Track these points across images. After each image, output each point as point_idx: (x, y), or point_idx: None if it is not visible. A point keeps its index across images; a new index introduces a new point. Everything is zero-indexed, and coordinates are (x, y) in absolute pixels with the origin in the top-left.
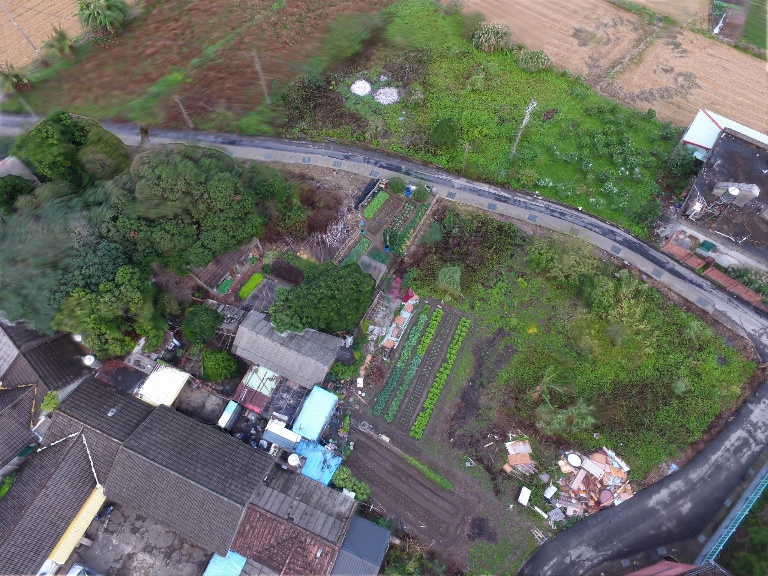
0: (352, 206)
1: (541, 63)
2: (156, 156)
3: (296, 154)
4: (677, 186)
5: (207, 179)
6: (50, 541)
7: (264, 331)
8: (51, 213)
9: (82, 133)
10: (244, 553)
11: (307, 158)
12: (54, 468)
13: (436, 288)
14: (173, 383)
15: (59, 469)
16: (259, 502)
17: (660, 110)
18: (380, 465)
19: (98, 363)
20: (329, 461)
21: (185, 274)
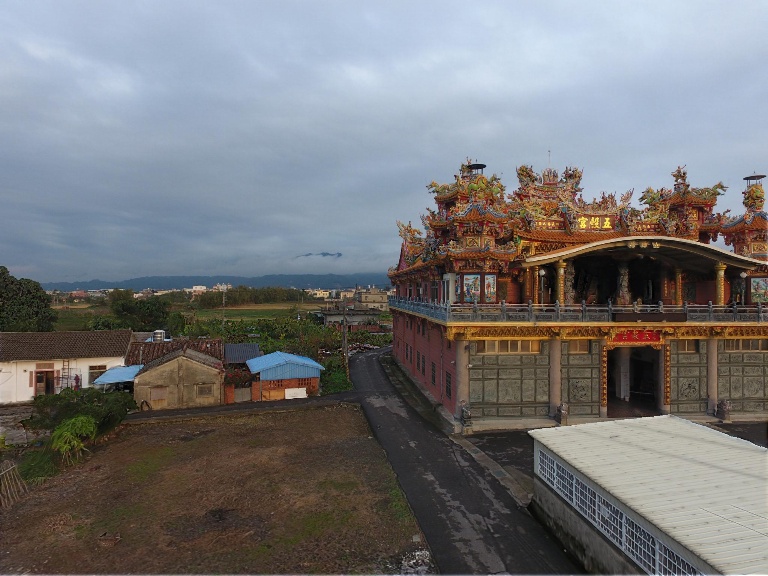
0: None
1: (217, 318)
2: None
3: None
4: None
5: None
6: None
7: None
8: None
9: None
10: None
11: None
12: None
13: None
14: None
15: None
16: None
17: None
18: None
19: None
20: None
21: None
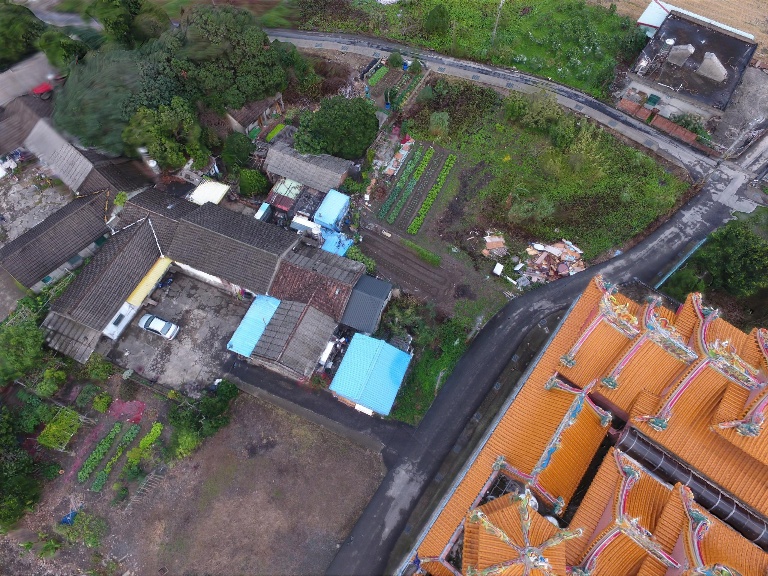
0: (358, 77)
1: None
2: (202, 8)
3: (310, 41)
4: (632, 61)
5: (242, 31)
6: (128, 288)
7: (289, 153)
8: (118, 54)
9: (136, 6)
10: (279, 297)
11: (319, 44)
12: (128, 239)
13: (429, 133)
14: (217, 192)
15: (132, 240)
16: (290, 260)
17: (621, 8)
18: (384, 251)
19: (159, 168)
20: (343, 242)
21: (224, 112)
